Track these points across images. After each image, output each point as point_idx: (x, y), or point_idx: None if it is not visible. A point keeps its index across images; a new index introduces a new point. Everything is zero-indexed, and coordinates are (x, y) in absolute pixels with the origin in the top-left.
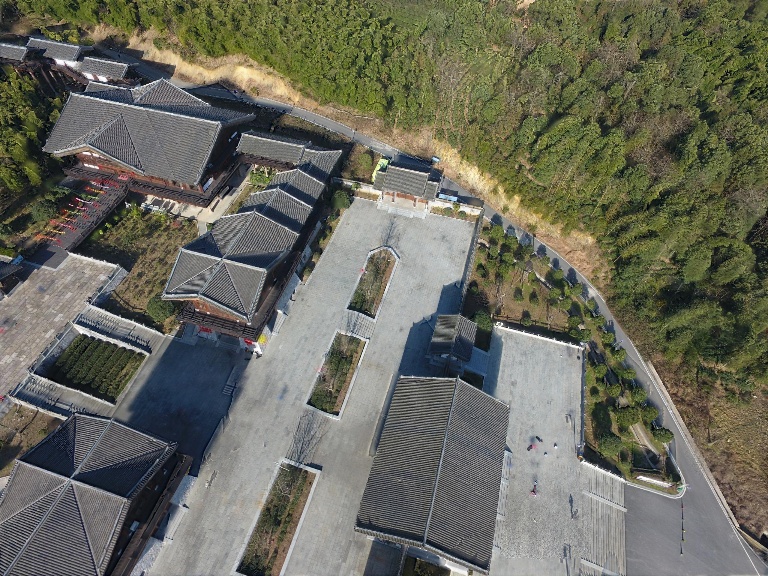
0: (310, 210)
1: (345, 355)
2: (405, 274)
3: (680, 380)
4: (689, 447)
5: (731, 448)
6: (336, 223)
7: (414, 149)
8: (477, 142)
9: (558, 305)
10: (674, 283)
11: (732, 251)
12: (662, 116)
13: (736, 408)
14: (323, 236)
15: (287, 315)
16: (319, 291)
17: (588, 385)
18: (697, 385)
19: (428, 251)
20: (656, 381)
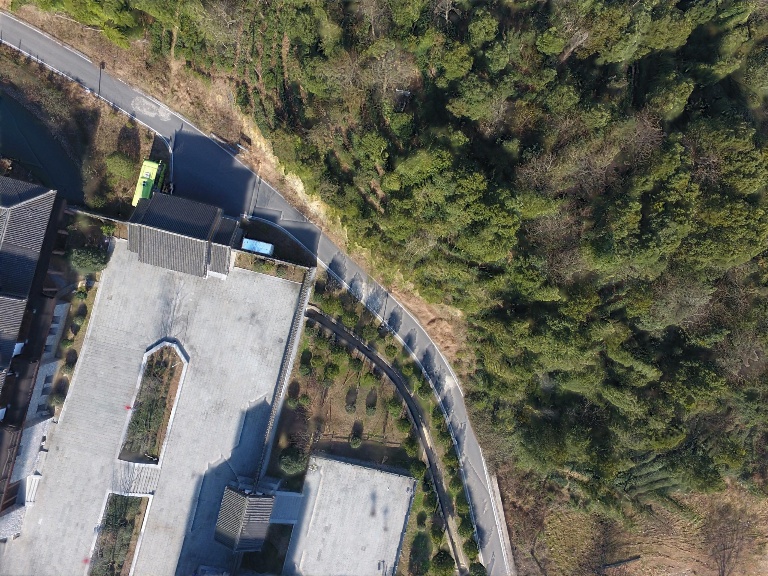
0: (2, 376)
1: (124, 520)
2: (197, 387)
3: (525, 487)
4: (506, 566)
5: (551, 556)
6: (92, 297)
7: (209, 113)
8: (294, 150)
9: (402, 407)
10: (550, 388)
11: (630, 376)
12: (610, 132)
13: (574, 513)
14: (75, 325)
15: (40, 475)
16: (78, 432)
17: (416, 510)
18: (541, 492)
19: (230, 344)
20: (495, 498)
